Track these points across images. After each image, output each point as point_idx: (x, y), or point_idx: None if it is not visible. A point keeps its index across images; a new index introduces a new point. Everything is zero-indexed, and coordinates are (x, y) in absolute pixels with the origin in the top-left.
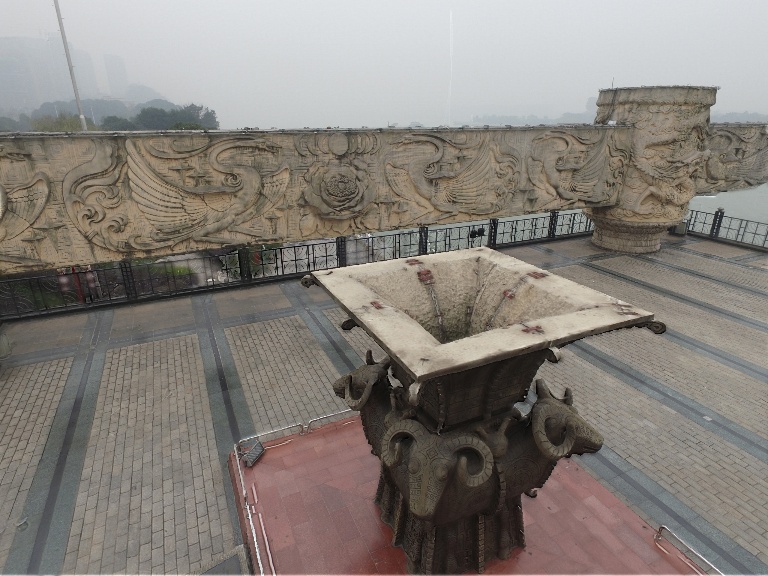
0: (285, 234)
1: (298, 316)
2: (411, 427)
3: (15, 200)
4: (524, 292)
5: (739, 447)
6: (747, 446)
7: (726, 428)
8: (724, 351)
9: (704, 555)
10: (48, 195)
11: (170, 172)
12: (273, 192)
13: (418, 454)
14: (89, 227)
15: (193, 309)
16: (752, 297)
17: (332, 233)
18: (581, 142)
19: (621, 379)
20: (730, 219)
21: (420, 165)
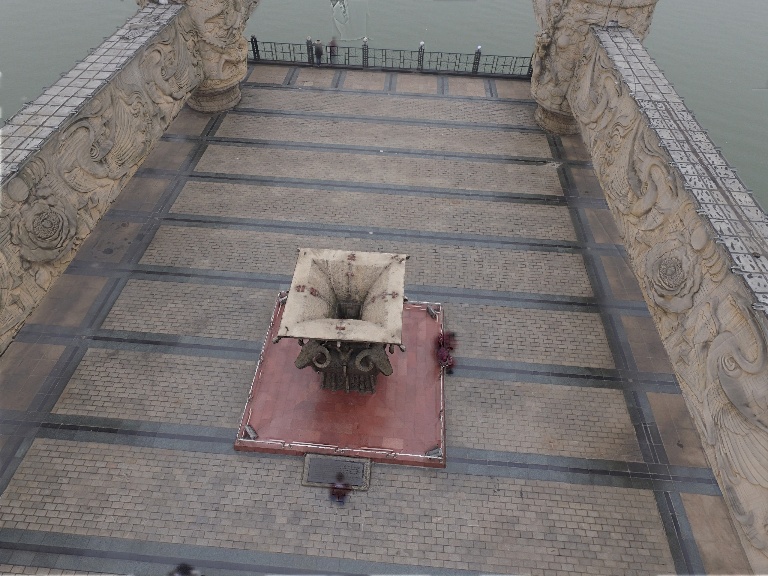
0: (32, 302)
1: (91, 349)
2: (366, 353)
3: None
4: (356, 271)
5: (390, 240)
6: (391, 238)
7: (380, 233)
8: (344, 181)
9: (414, 298)
10: None
11: None
12: None
13: (376, 359)
14: None
15: None
16: (322, 123)
17: (63, 267)
18: (166, 44)
19: (327, 236)
20: (263, 44)
21: (86, 154)
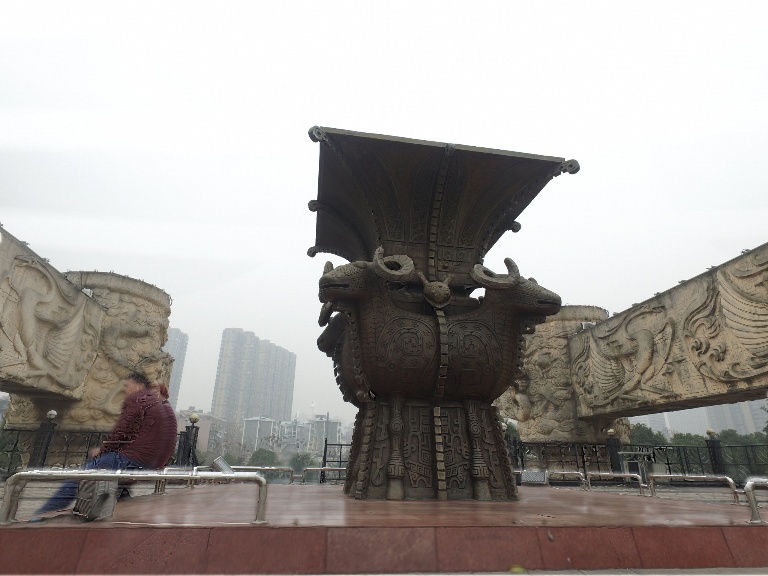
0: None
1: None
2: None
3: (657, 342)
4: None
5: None
6: None
7: None
8: None
9: None
10: (673, 334)
11: (757, 289)
12: None
13: None
14: (698, 358)
15: None
16: None
17: None
18: None
19: None
20: None
21: None
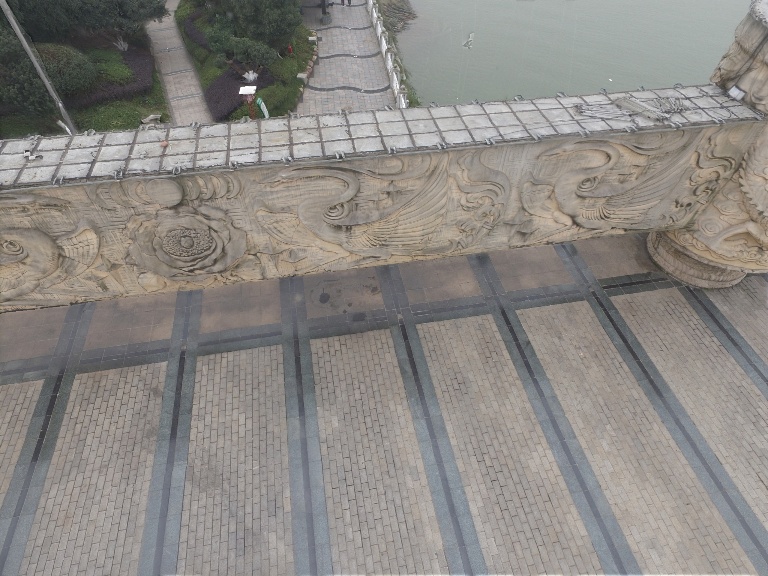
0: (122, 290)
1: (165, 365)
2: None
3: None
4: None
5: None
6: None
7: None
8: None
9: None
10: None
11: None
12: (81, 254)
13: None
14: None
15: (65, 321)
16: None
17: (192, 286)
18: (639, 153)
19: None
20: None
21: (316, 208)
